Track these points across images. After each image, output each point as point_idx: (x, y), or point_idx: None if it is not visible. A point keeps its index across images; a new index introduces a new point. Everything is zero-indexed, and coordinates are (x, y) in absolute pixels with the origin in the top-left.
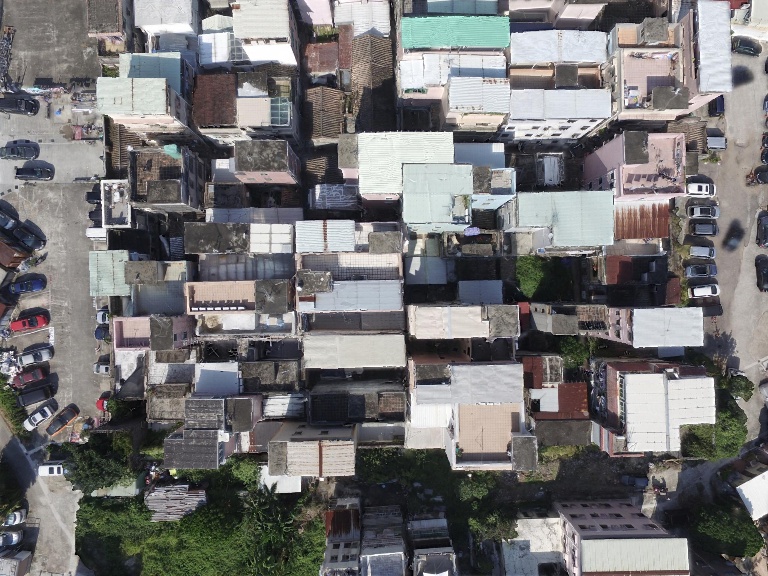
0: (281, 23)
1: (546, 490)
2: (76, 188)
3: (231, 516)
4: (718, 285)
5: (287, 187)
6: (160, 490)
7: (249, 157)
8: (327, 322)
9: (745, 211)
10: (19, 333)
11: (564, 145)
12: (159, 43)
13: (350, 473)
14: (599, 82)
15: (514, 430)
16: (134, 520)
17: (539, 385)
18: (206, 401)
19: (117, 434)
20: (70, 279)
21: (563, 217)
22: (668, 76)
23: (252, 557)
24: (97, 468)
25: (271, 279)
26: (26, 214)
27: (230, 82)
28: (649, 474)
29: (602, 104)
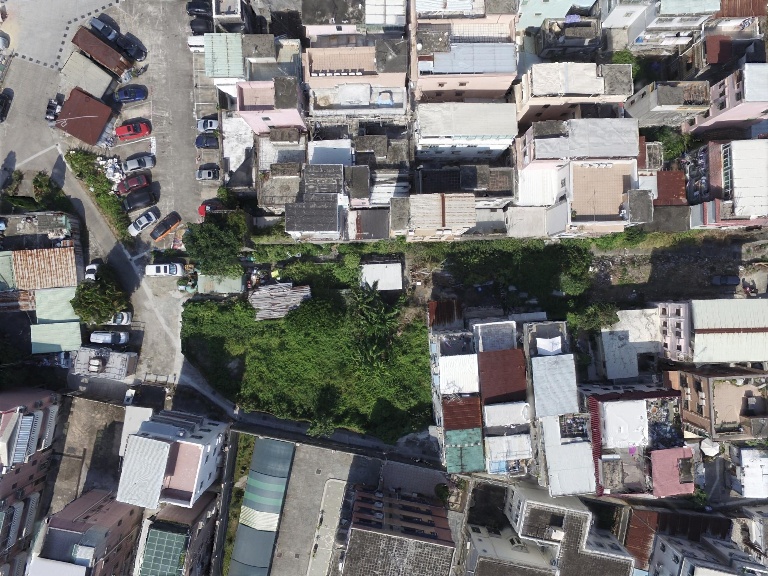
0: None
1: (639, 292)
2: (175, 2)
3: (336, 308)
4: None
5: None
6: (264, 289)
7: None
8: None
9: None
10: (122, 142)
11: None
12: None
13: (472, 224)
14: None
15: (626, 192)
16: (239, 317)
17: (642, 163)
18: (325, 166)
19: (232, 213)
20: (170, 90)
21: None
22: None
23: (356, 350)
24: (217, 238)
25: (391, 39)
26: (127, 27)
27: None
28: (739, 276)
29: None
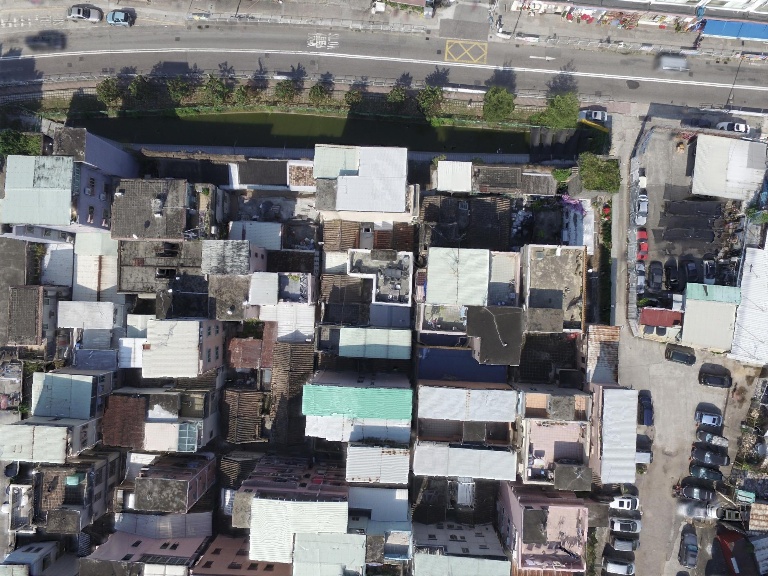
0: (190, 363)
1: None
2: None
3: None
4: None
5: None
6: None
7: (149, 496)
8: None
9: (669, 523)
10: None
11: None
12: (83, 337)
13: None
14: (509, 432)
15: None
16: None
17: None
18: None
19: None
20: None
21: None
22: (577, 442)
23: None
24: None
25: None
26: None
27: (140, 406)
28: None
29: (507, 467)
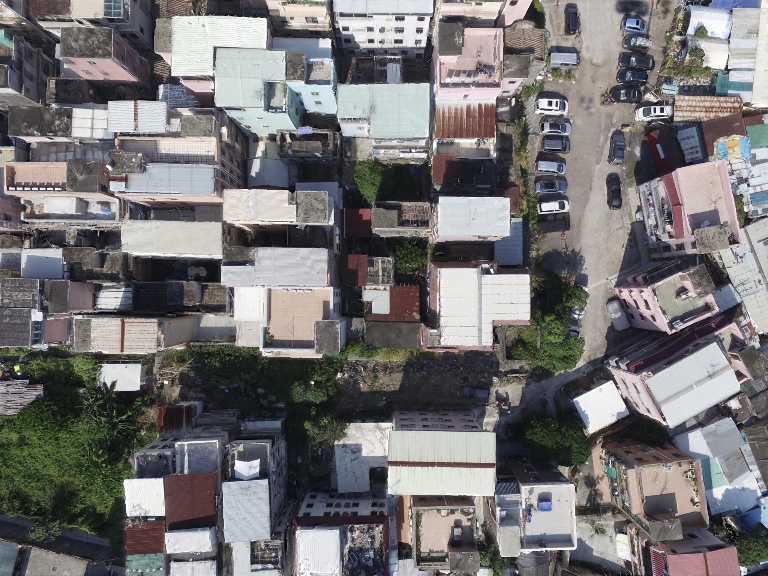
0: None
1: (388, 400)
2: None
3: (66, 410)
4: (568, 202)
5: (131, 86)
6: (1, 384)
7: (74, 43)
8: (164, 219)
9: (598, 130)
10: None
11: (416, 58)
12: None
13: (152, 350)
14: None
15: (325, 318)
16: None
17: (363, 282)
18: (22, 280)
19: None
20: None
21: (380, 109)
22: None
23: (87, 452)
24: None
25: (83, 158)
26: None
27: None
28: (493, 388)
29: None
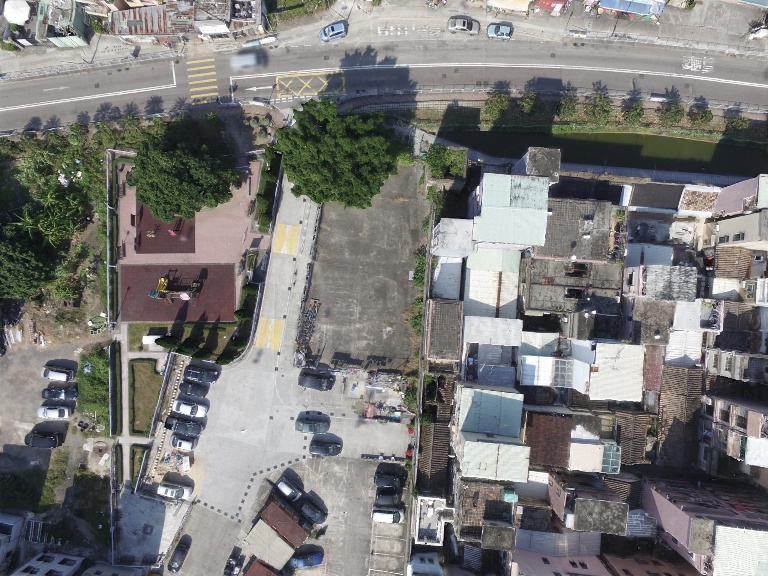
0: (635, 387)
1: None
2: (362, 464)
3: None
4: None
5: None
6: None
7: (589, 517)
8: None
9: None
10: None
11: None
12: None
13: None
14: None
15: None
16: None
17: None
18: None
19: None
20: (346, 554)
21: None
22: None
23: None
24: None
25: None
26: (311, 485)
27: (566, 426)
28: None
29: None
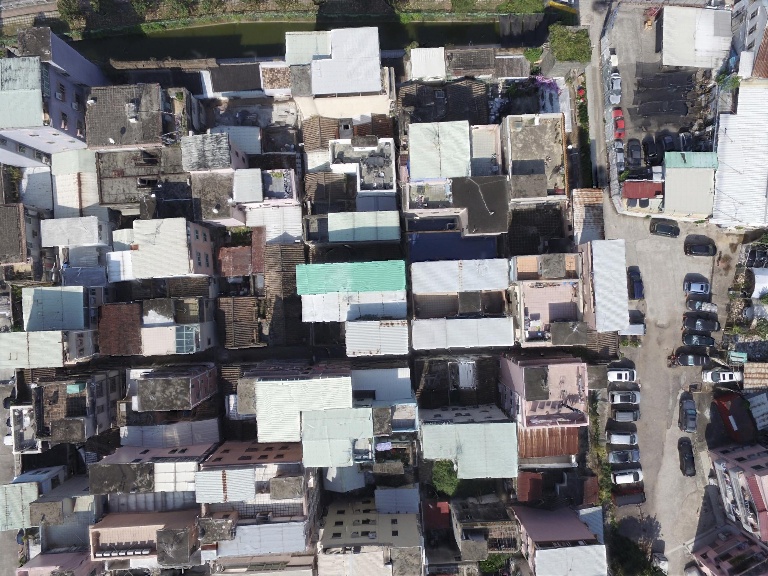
0: (180, 260)
1: None
2: None
3: None
4: (641, 469)
5: None
6: None
7: (152, 396)
8: None
9: (667, 393)
10: None
11: None
12: (69, 257)
13: None
14: (504, 303)
15: None
16: None
17: None
18: None
19: None
20: None
21: (467, 450)
22: (570, 302)
23: None
24: None
25: (172, 529)
26: None
27: (134, 312)
28: None
29: (504, 333)
